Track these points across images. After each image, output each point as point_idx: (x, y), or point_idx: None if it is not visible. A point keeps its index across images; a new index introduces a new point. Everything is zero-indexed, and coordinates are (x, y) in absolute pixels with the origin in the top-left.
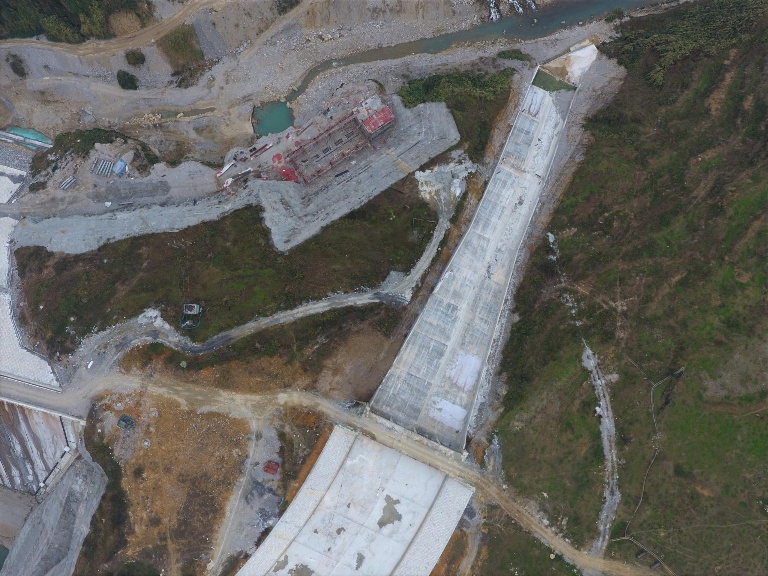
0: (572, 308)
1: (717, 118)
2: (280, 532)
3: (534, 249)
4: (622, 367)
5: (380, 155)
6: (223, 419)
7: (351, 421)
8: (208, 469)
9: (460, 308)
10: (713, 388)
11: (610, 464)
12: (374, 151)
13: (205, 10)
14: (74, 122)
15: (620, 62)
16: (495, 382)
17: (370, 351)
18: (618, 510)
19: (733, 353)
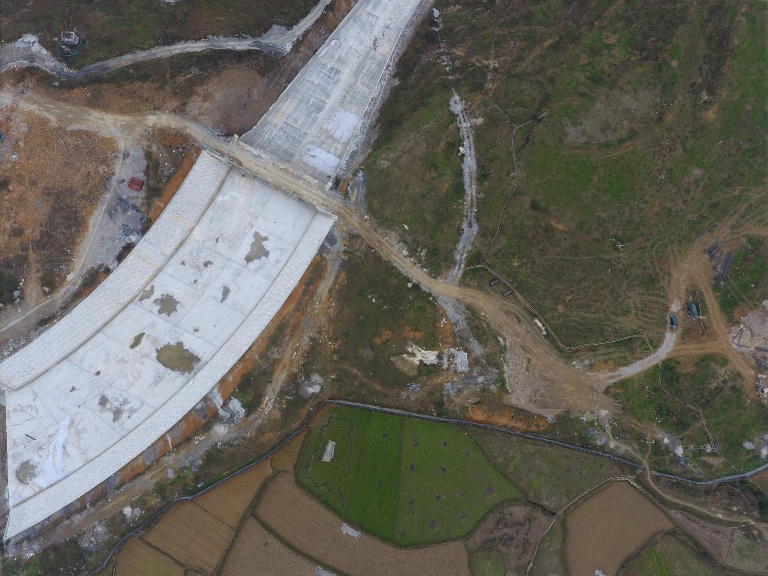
0: (447, 66)
1: None
2: (144, 253)
3: (419, 24)
4: (487, 112)
5: None
6: (92, 137)
7: (219, 147)
8: (74, 184)
9: (343, 72)
10: (574, 134)
11: (469, 198)
12: None
13: None
14: None
15: None
16: (369, 134)
17: (242, 83)
18: (475, 241)
19: (594, 102)
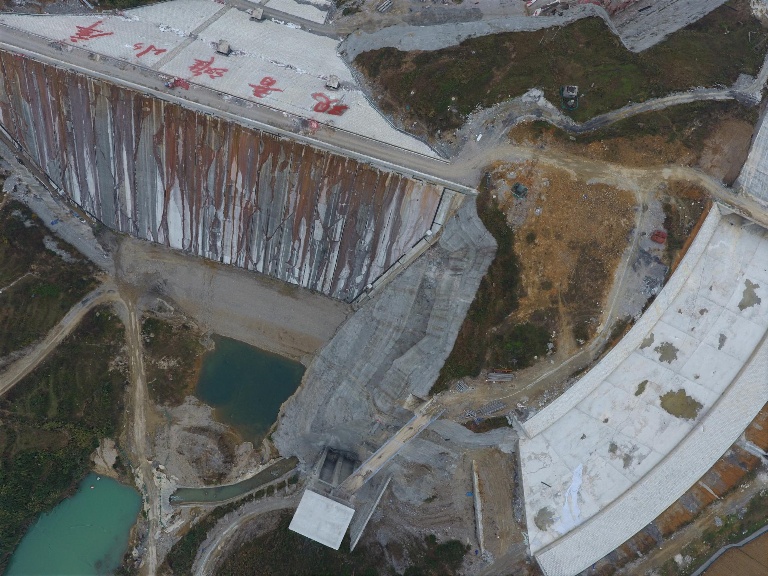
0: None
1: None
2: (659, 303)
3: None
4: None
5: None
6: (611, 190)
7: (728, 199)
8: (597, 237)
9: None
10: None
11: None
12: None
13: None
14: None
15: None
16: None
17: (743, 135)
18: None
19: None
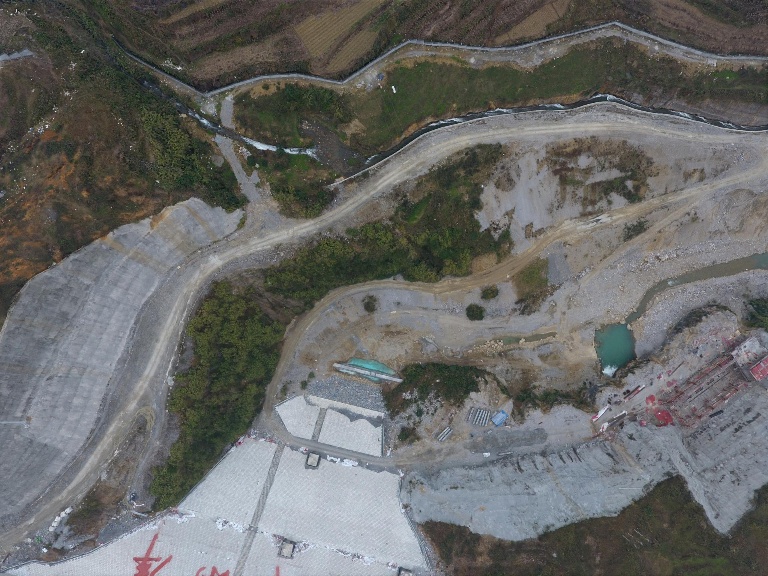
0: None
1: None
2: None
3: None
4: None
5: (757, 396)
6: None
7: None
8: None
9: None
10: None
11: None
12: (746, 389)
13: (559, 244)
14: (417, 352)
15: None
16: None
17: None
18: None
19: None
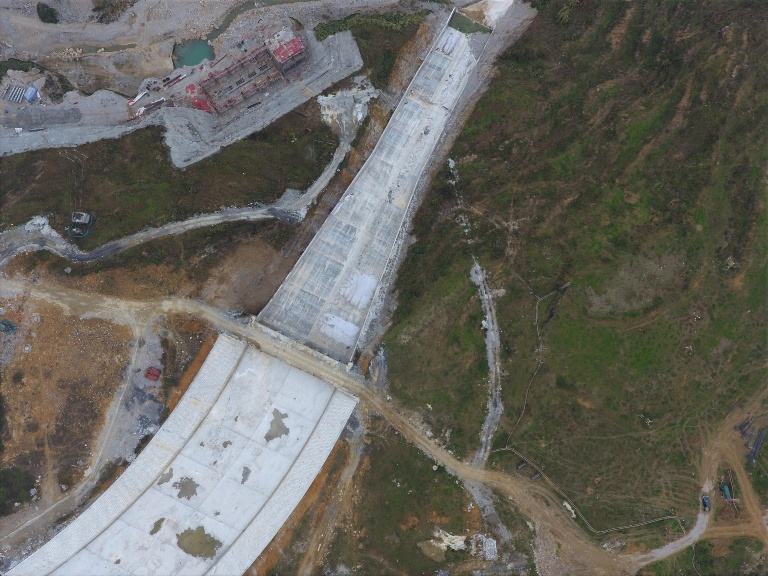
0: (465, 227)
1: (617, 51)
2: (162, 441)
3: (435, 175)
4: (509, 282)
5: (292, 87)
6: (106, 325)
7: (236, 330)
8: (89, 375)
9: (359, 230)
10: (598, 304)
11: (494, 376)
12: (287, 84)
13: None
14: None
15: (533, 5)
16: (388, 300)
17: (258, 261)
18: (501, 422)
19: (618, 270)
